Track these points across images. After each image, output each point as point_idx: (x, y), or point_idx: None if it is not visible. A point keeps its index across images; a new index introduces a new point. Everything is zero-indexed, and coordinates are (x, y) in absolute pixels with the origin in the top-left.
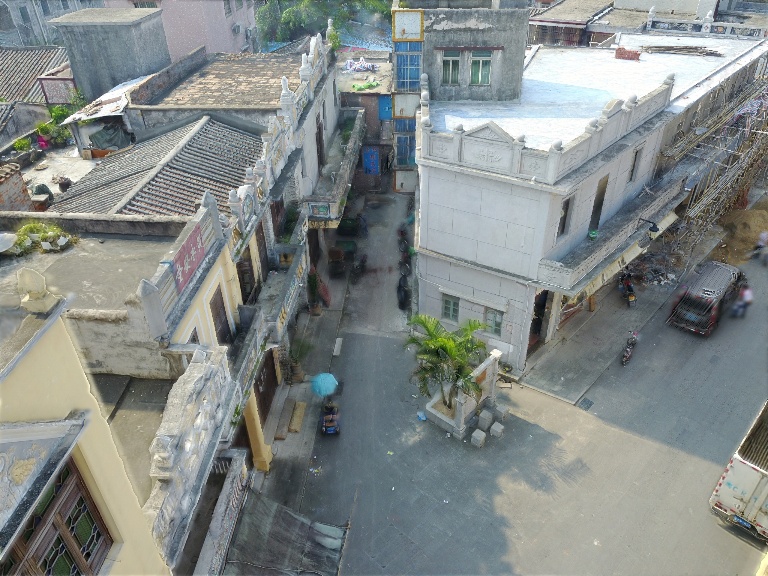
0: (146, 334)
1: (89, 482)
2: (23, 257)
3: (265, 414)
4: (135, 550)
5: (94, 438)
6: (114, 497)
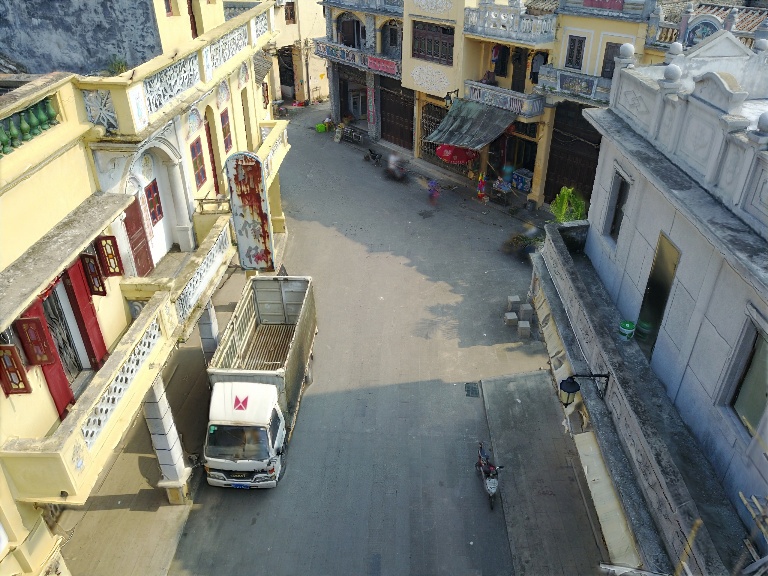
0: None
1: None
2: None
3: None
4: (458, 1)
5: None
6: None
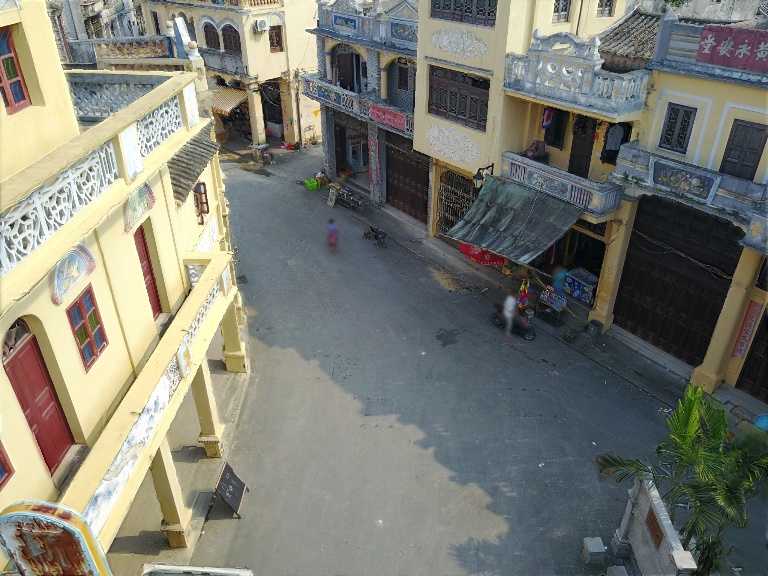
0: None
1: None
2: None
3: None
4: None
5: None
6: (500, 4)
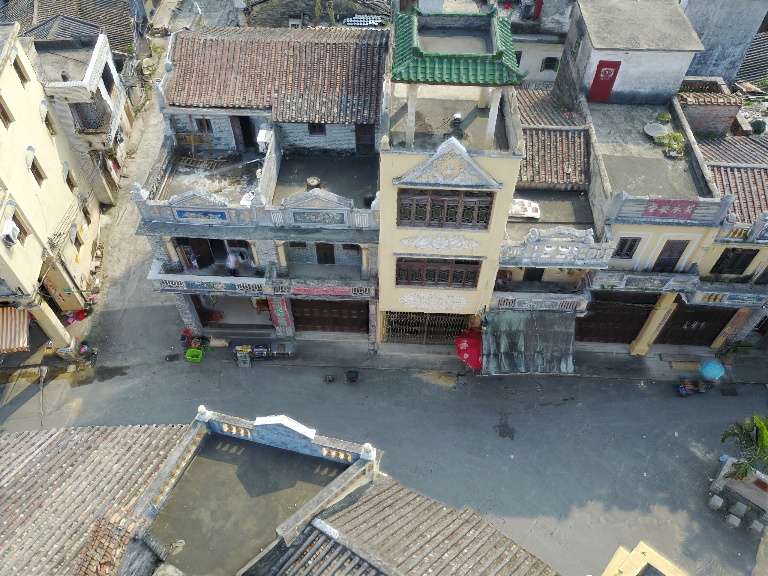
0: (606, 211)
1: (493, 206)
2: (654, 145)
3: (676, 342)
4: (491, 241)
5: (504, 197)
6: (497, 218)
